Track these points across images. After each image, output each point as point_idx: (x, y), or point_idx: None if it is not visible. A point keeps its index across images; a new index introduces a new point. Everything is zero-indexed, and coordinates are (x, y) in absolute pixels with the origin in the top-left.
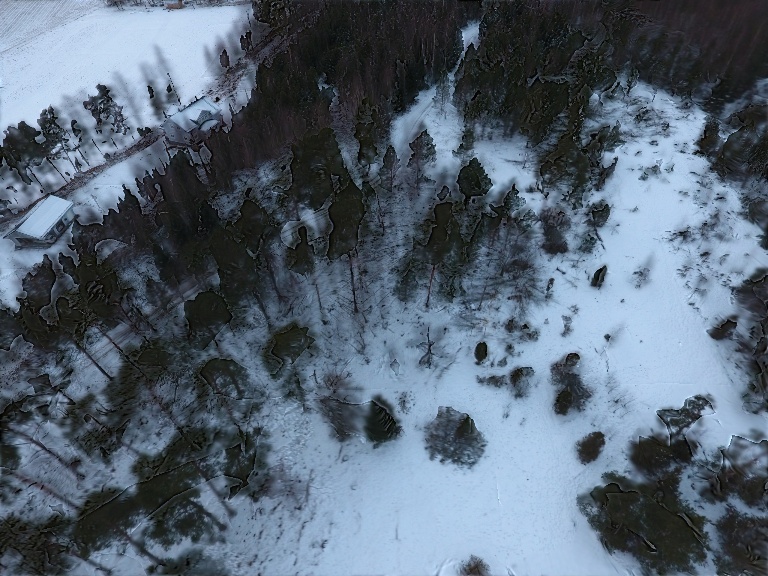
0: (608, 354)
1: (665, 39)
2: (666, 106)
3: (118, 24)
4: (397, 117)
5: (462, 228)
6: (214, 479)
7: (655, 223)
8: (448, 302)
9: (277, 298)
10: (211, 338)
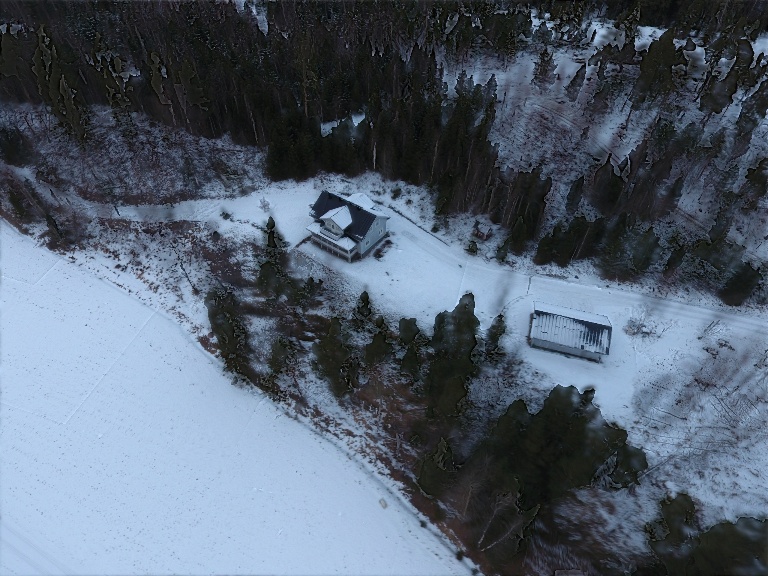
0: None
1: None
2: None
3: None
4: None
5: None
6: None
7: None
8: None
9: None
10: None
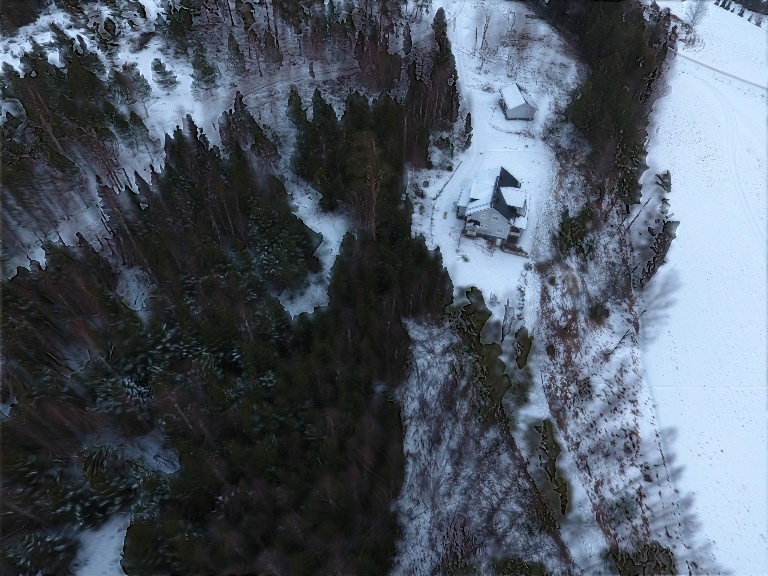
0: None
1: None
2: None
3: None
4: None
5: None
6: None
7: None
8: None
9: None
10: None
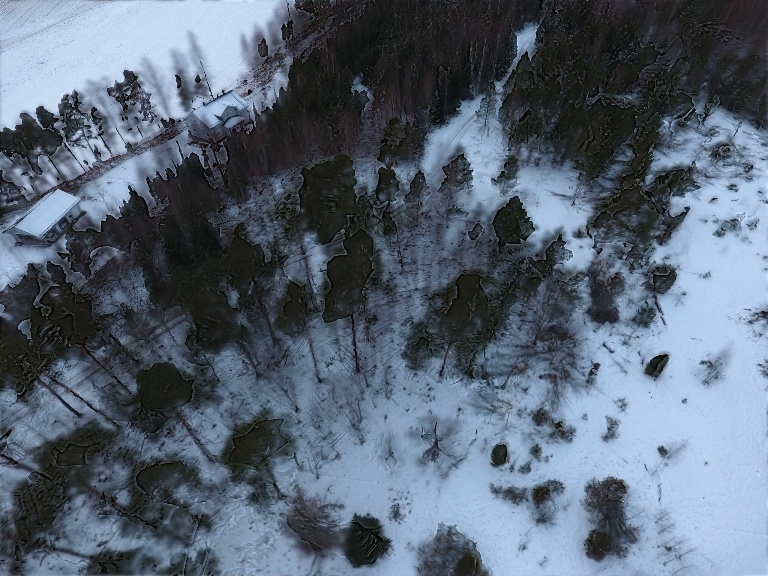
0: (662, 478)
1: (755, 61)
2: (749, 141)
3: (164, 4)
4: (434, 129)
5: (493, 276)
6: (163, 574)
7: (731, 296)
8: (466, 377)
9: (271, 341)
10: (164, 421)
